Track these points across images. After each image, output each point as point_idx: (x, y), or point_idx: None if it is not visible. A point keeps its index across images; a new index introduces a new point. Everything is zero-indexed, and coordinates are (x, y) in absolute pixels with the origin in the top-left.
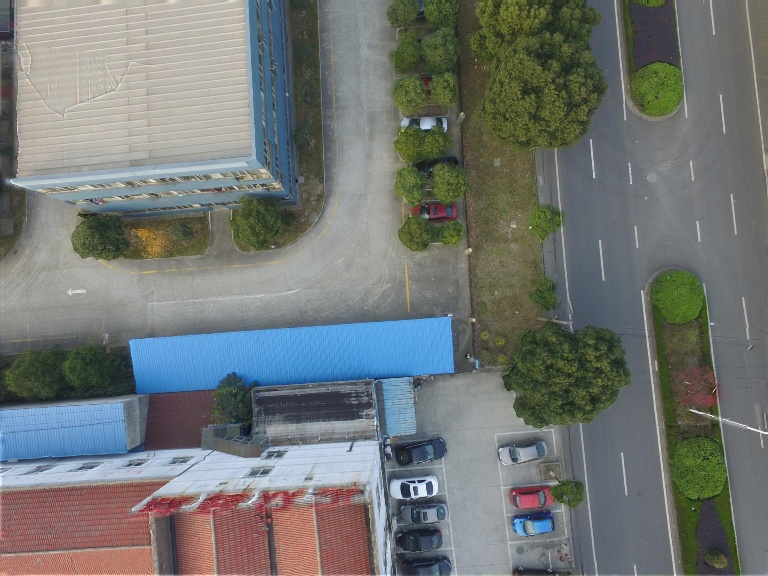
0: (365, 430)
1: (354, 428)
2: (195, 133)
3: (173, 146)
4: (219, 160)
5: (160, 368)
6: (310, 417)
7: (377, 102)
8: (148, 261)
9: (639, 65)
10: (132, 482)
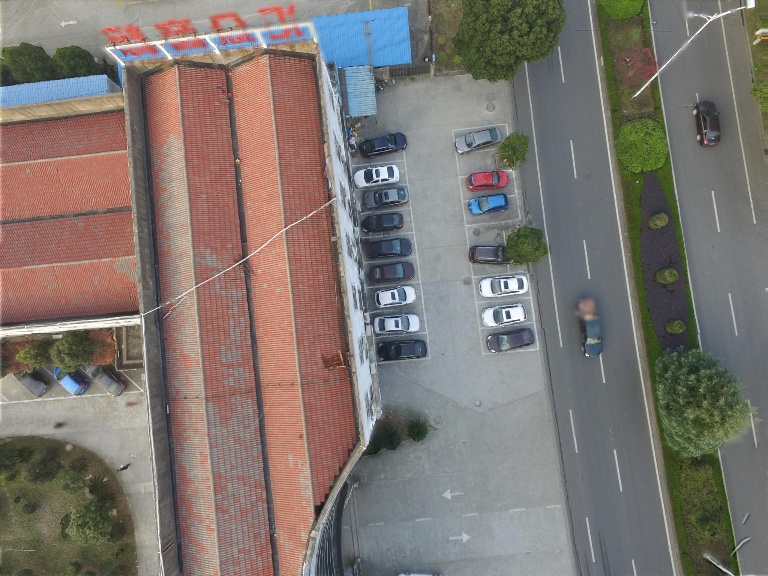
0: None
1: None
2: None
3: None
4: None
5: None
6: None
7: None
8: None
9: None
10: (112, 113)
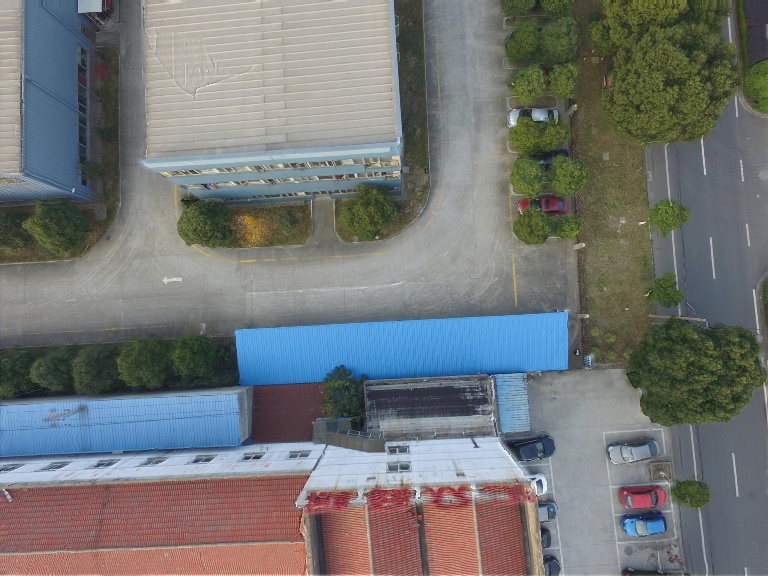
0: (482, 426)
1: (471, 424)
2: (335, 117)
3: (312, 130)
4: (364, 145)
5: (266, 359)
6: (424, 412)
7: (483, 92)
8: (247, 250)
9: (753, 61)
10: None
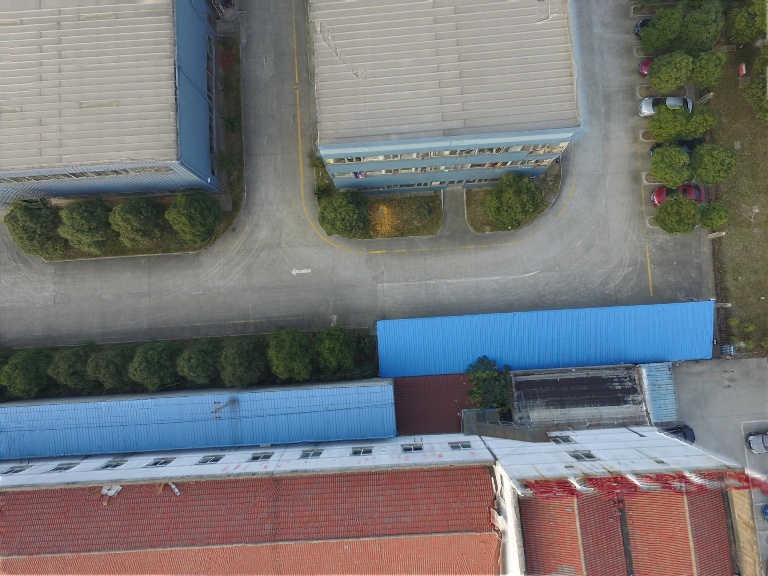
0: (634, 416)
1: (622, 414)
2: (514, 102)
3: (490, 115)
4: (549, 130)
5: (407, 351)
6: (574, 402)
7: (612, 81)
8: (376, 241)
9: None
10: None
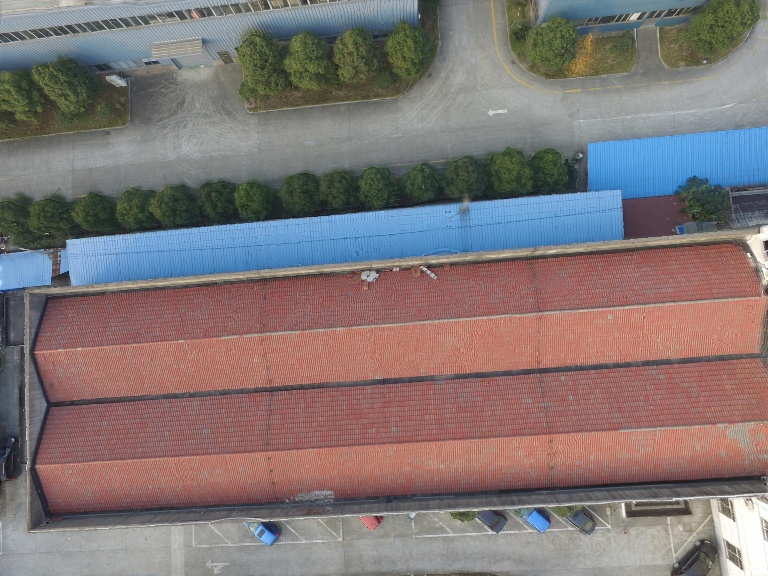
0: None
1: None
2: None
3: None
4: None
5: (617, 173)
6: None
7: None
8: (571, 80)
9: None
10: (683, 247)
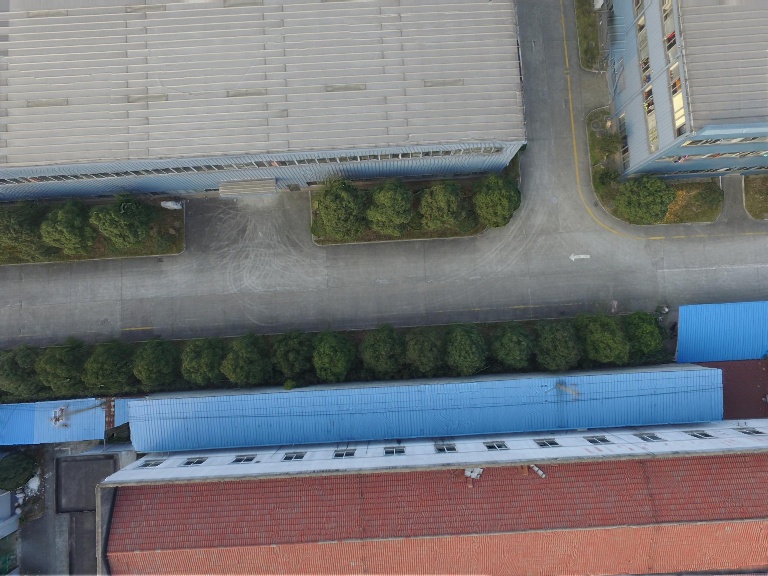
0: None
1: None
2: None
3: None
4: None
5: (707, 336)
6: None
7: None
8: (654, 227)
9: None
10: None
